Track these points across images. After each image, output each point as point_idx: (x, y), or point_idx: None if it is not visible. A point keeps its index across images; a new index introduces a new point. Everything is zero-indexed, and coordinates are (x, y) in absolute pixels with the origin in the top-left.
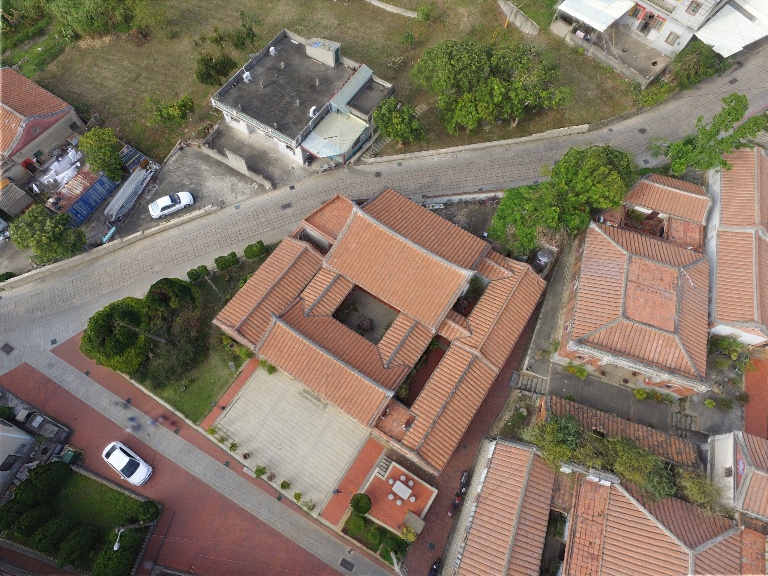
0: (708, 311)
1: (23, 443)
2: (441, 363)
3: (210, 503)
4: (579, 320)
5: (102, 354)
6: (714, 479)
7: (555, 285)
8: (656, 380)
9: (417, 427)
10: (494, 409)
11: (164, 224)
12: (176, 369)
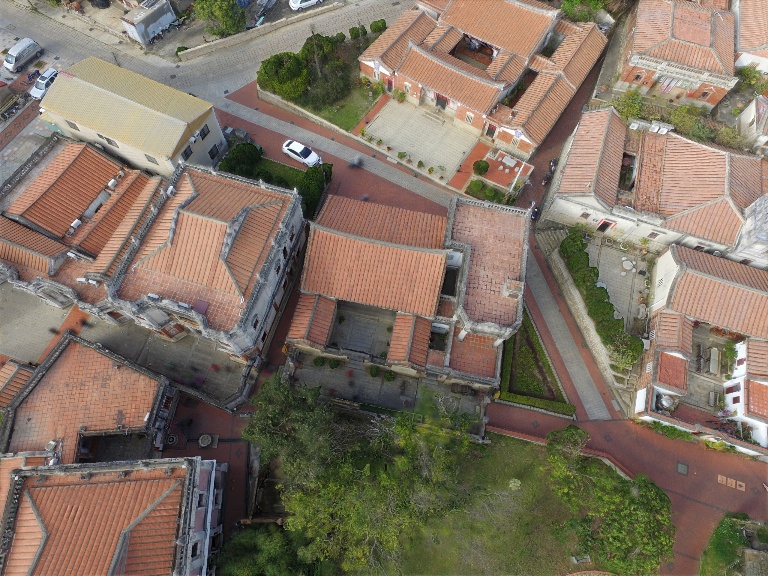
0: (734, 42)
1: (222, 141)
2: (533, 83)
3: (365, 178)
4: (638, 45)
5: (276, 81)
6: (741, 135)
7: (613, 48)
8: (696, 86)
9: (520, 116)
10: (571, 126)
11: (302, 14)
12: (330, 95)
